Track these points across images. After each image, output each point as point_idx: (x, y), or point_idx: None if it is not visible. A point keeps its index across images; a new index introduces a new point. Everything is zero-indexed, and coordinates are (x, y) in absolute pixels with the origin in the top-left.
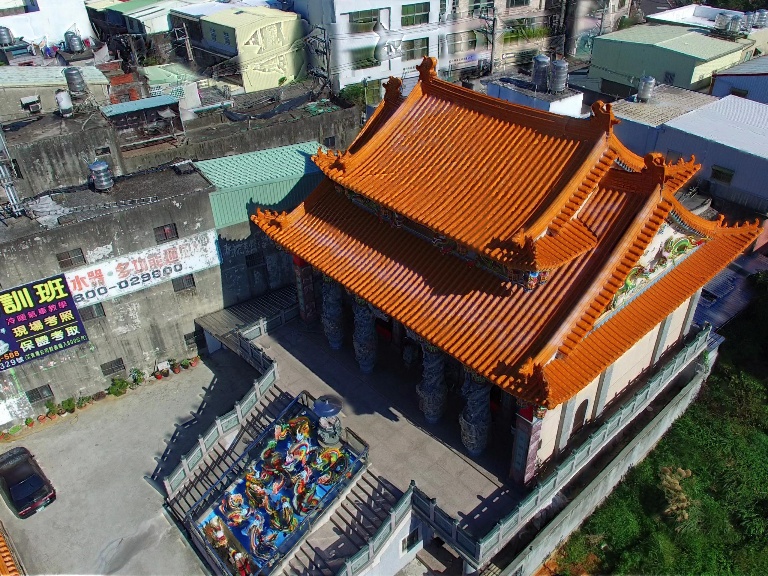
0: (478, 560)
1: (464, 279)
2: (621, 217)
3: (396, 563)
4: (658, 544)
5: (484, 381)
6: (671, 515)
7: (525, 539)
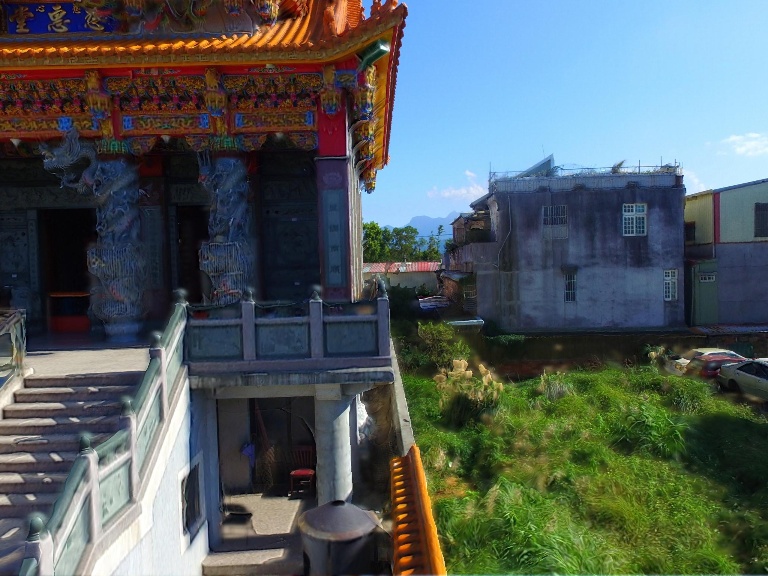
0: (388, 352)
1: (148, 41)
2: (318, 1)
3: (175, 570)
4: (503, 418)
5: (239, 146)
6: (482, 407)
7: (378, 445)
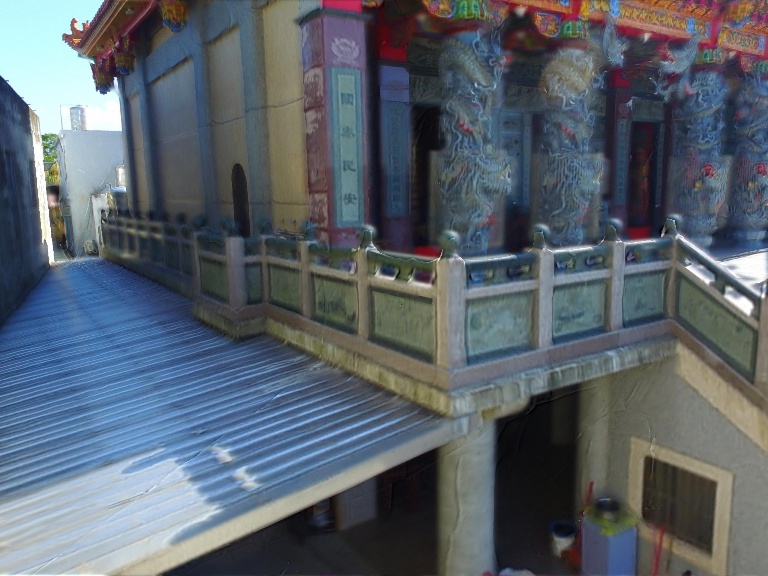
0: None
1: None
2: None
3: None
4: None
5: None
6: None
7: None
